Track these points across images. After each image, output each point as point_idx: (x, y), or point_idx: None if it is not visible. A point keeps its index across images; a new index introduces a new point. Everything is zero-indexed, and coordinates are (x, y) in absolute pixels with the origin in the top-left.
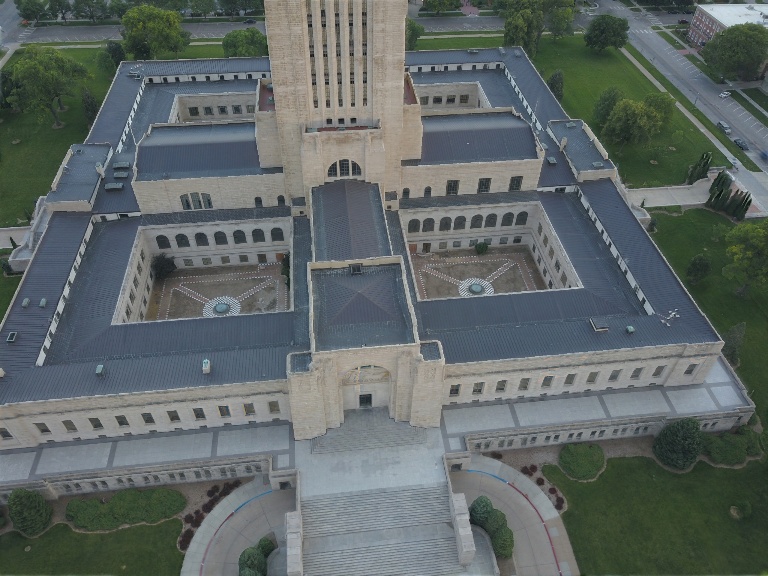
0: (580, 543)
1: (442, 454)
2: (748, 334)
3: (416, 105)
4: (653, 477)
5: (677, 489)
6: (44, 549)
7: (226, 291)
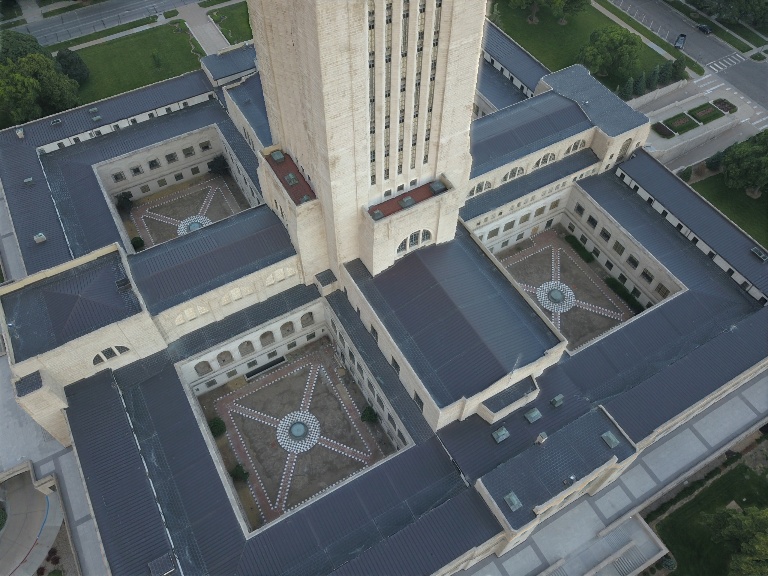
0: None
1: (34, 460)
2: None
3: (372, 220)
4: None
5: None
6: None
7: None
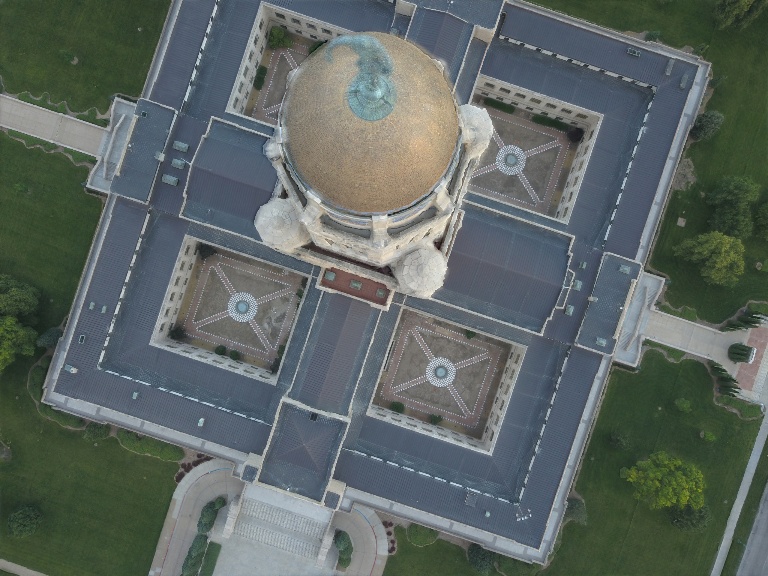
0: (388, 574)
1: None
2: (610, 499)
3: None
4: (457, 560)
5: (464, 573)
6: (104, 449)
7: (251, 288)
